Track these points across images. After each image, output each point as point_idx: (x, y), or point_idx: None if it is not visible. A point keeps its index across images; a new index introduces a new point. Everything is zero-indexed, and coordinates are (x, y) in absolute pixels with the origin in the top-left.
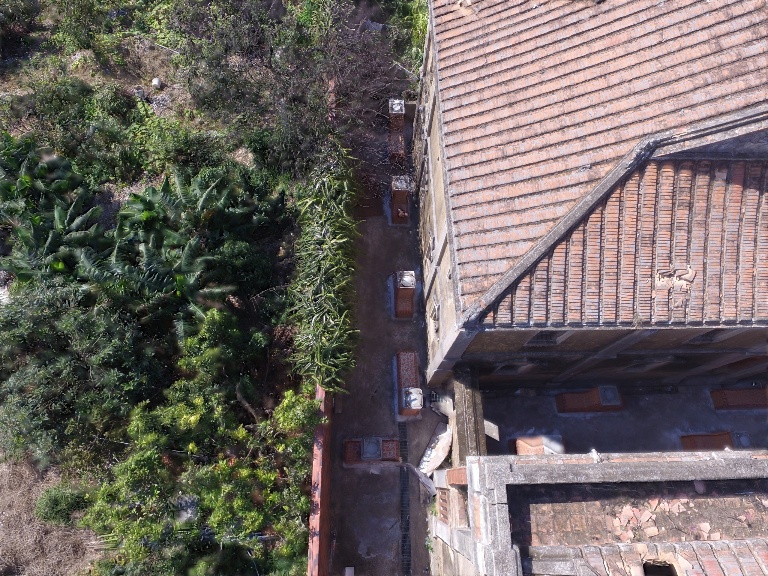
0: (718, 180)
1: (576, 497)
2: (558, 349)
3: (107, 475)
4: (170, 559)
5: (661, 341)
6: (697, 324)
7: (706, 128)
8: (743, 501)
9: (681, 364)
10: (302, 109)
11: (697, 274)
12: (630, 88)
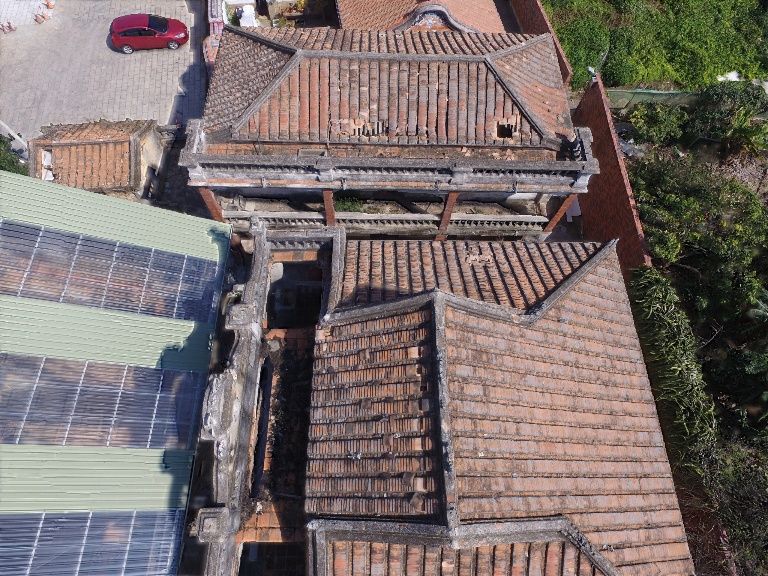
0: None
1: (532, 170)
2: None
3: (761, 217)
4: (702, 189)
5: None
6: None
7: None
8: None
9: None
10: (767, 523)
11: None
12: (538, 381)
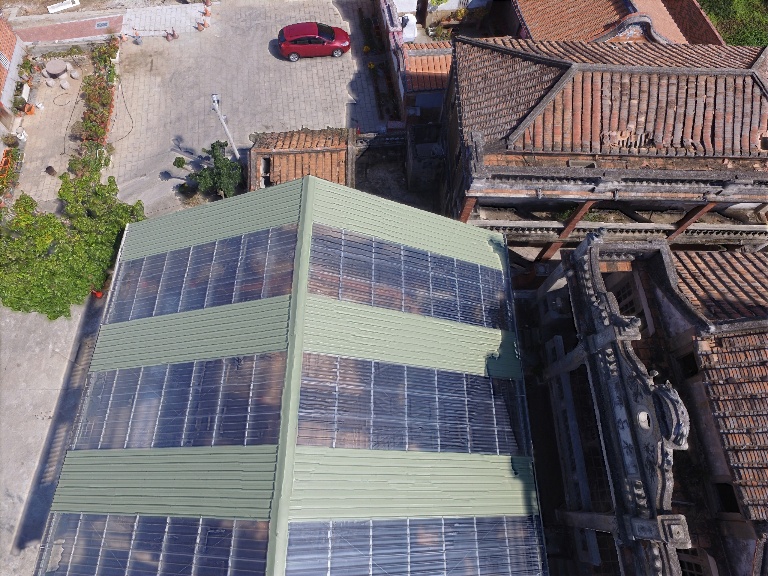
0: None
1: None
2: None
3: None
4: None
5: None
6: None
7: None
8: None
9: None
10: None
11: None
12: None
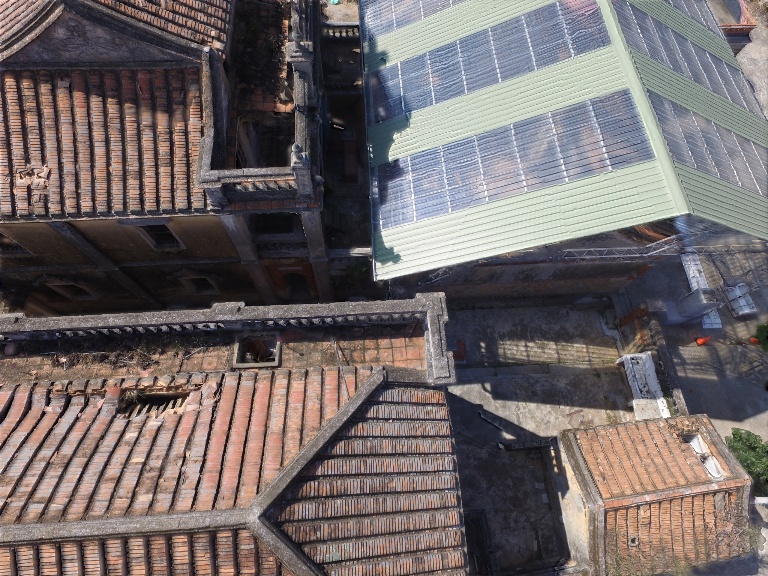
0: (61, 88)
1: None
2: (53, 262)
3: None
4: None
5: (128, 248)
6: (61, 217)
7: (9, 38)
8: (44, 359)
9: (230, 281)
10: None
11: (53, 172)
12: (5, 12)
